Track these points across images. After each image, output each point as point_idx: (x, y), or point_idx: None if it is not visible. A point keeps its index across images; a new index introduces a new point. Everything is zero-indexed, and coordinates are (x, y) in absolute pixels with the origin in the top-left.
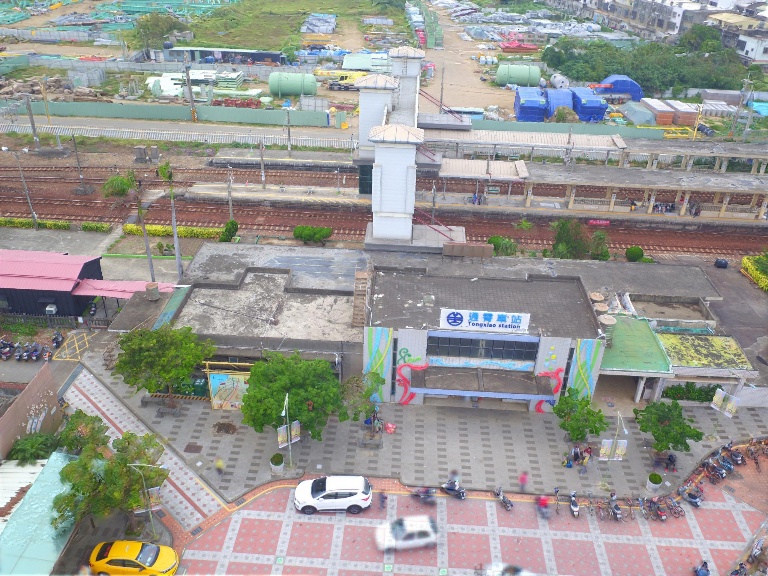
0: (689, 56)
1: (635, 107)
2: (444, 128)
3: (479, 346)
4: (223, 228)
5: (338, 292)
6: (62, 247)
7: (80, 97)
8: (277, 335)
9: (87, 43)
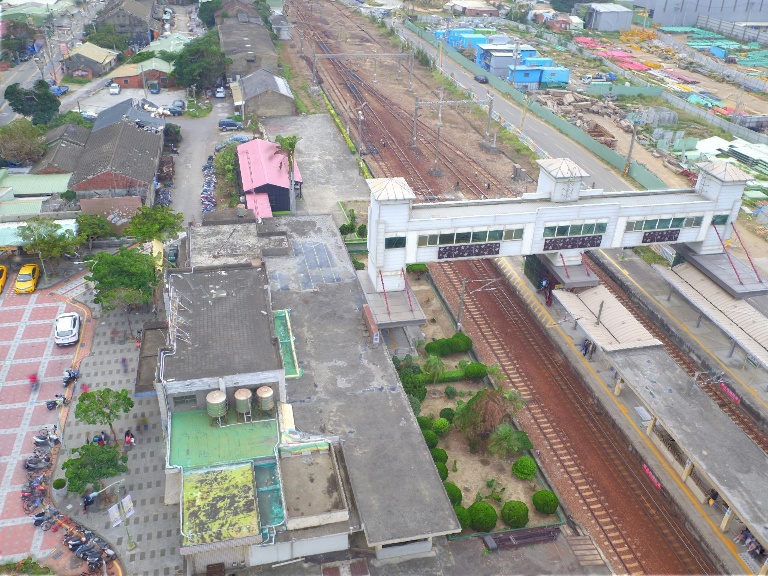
0: None
1: None
2: (712, 278)
3: None
4: None
5: None
6: (342, 187)
7: None
8: (200, 260)
9: None
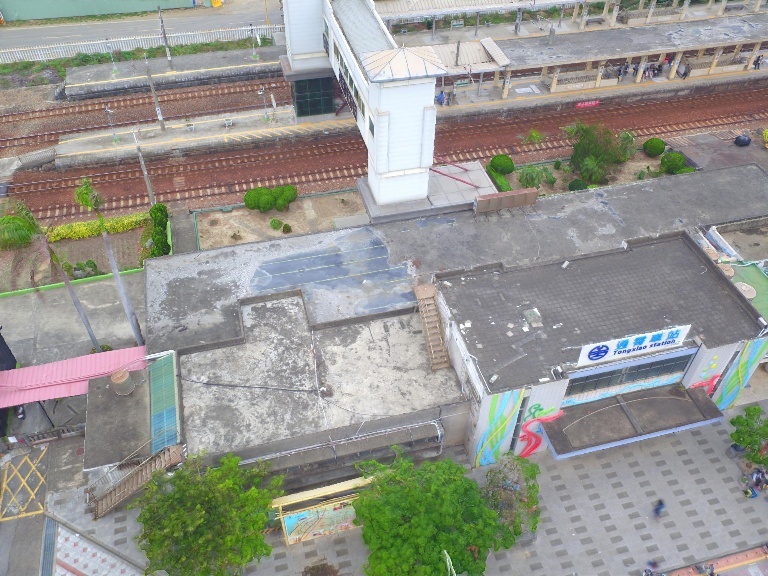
0: None
1: None
2: None
3: (621, 373)
4: (142, 213)
5: (384, 314)
6: None
7: None
8: (343, 415)
9: None
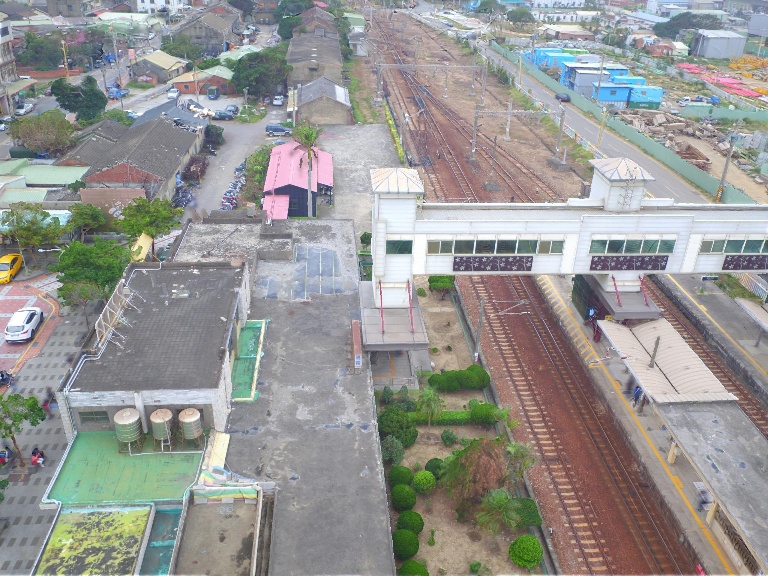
0: None
1: None
2: None
3: None
4: None
5: None
6: None
7: None
8: (185, 259)
9: None
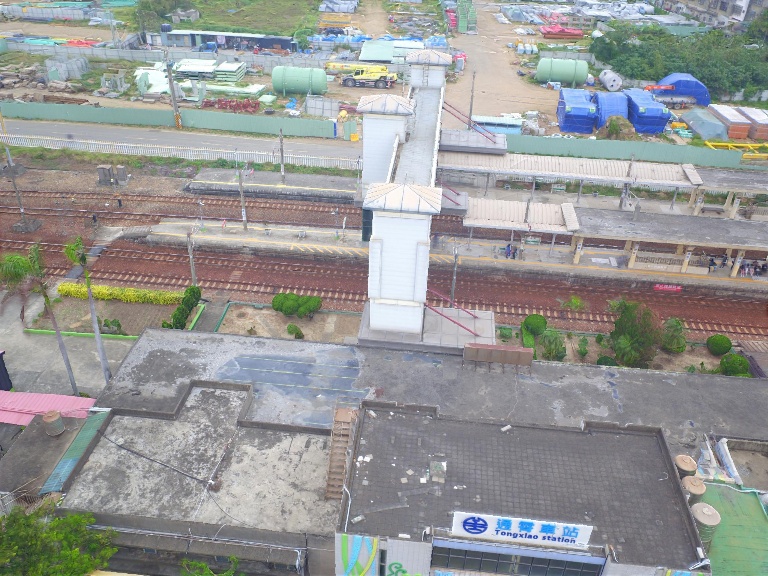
0: (763, 50)
1: (703, 117)
2: (473, 151)
3: (511, 560)
4: (184, 292)
5: (312, 430)
6: None
7: (53, 94)
8: (215, 513)
9: (82, 22)
